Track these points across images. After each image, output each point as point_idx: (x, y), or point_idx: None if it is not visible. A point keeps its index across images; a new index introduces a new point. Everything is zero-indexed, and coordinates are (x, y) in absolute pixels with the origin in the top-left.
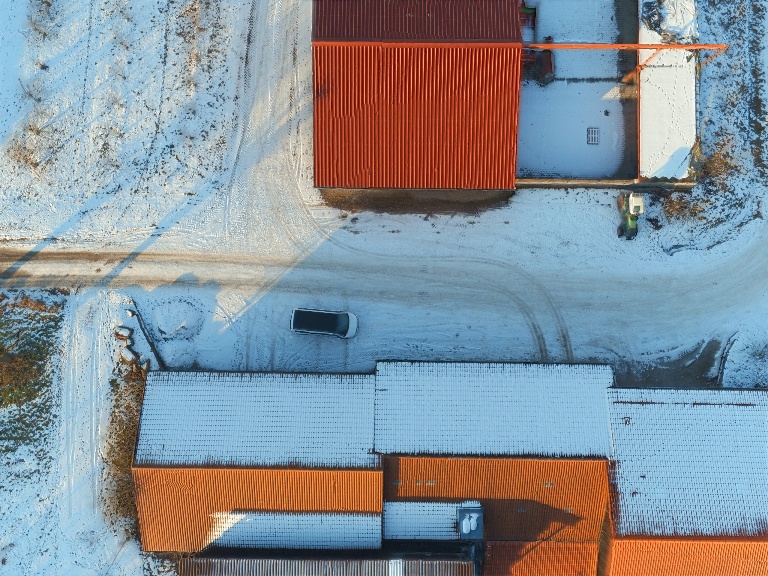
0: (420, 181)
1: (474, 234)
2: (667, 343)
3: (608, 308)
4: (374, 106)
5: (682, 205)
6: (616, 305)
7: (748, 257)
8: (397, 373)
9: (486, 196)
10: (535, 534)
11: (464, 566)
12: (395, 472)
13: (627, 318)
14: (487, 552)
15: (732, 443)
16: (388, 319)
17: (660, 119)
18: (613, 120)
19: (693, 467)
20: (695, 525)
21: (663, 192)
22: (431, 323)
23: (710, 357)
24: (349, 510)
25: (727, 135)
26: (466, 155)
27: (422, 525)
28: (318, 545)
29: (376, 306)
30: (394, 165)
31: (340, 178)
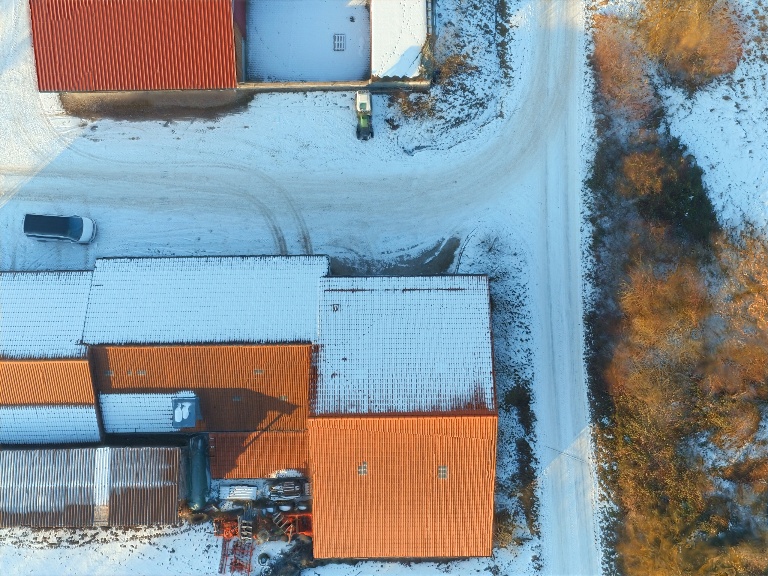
0: (143, 83)
1: (214, 139)
2: (407, 242)
3: (349, 209)
4: (90, 8)
5: (420, 105)
6: (357, 206)
7: (488, 155)
8: (115, 269)
9: (226, 101)
10: (254, 424)
11: (170, 452)
12: (105, 363)
13: (368, 218)
14: (210, 444)
15: (436, 325)
16: (129, 225)
17: (391, 19)
18: (359, 26)
19: (395, 349)
20: (389, 403)
21: (401, 93)
22: (173, 228)
23: (449, 254)
24: (62, 402)
25: (468, 37)
26: (186, 55)
27: (141, 417)
28: (38, 439)
29: (117, 212)
30: (116, 67)
31: (64, 82)
